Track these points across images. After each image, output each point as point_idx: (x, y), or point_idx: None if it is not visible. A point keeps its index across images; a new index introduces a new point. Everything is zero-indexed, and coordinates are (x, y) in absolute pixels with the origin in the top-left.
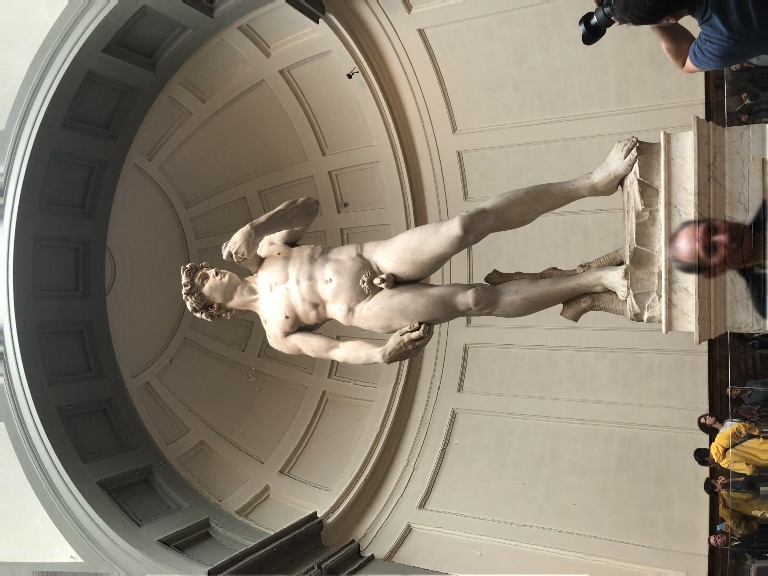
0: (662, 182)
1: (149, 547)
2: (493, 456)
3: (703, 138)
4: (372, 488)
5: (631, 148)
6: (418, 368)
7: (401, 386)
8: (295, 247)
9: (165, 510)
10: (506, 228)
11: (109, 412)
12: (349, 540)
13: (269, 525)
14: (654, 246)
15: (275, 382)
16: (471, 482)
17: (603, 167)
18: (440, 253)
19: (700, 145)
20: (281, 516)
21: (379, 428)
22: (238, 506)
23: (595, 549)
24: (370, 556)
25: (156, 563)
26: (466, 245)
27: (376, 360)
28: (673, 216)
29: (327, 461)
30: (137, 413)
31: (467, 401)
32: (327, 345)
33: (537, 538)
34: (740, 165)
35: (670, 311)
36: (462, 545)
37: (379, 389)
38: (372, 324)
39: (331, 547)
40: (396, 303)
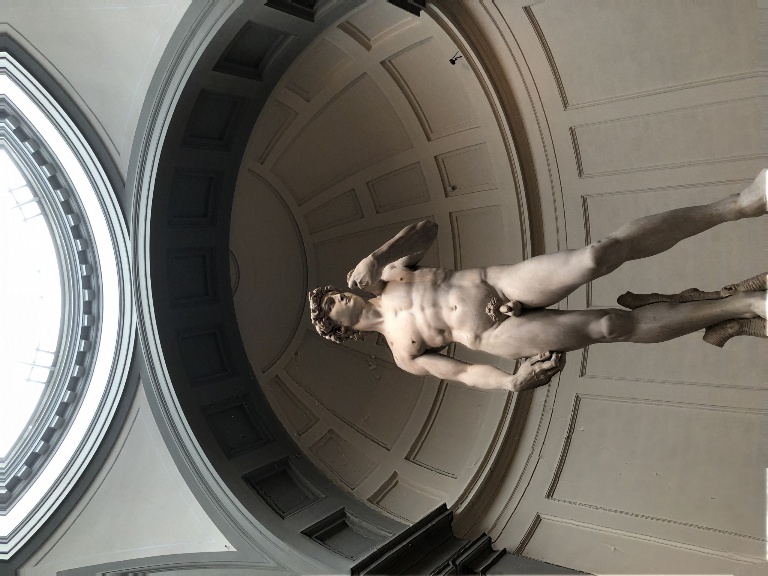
0: None
1: (294, 540)
2: (622, 444)
3: None
4: (498, 477)
5: None
6: None
7: None
8: (417, 270)
9: (303, 500)
10: None
11: (245, 408)
12: (479, 530)
13: (400, 513)
14: None
15: (395, 369)
16: (600, 471)
17: (752, 190)
18: (570, 284)
19: None
20: (411, 504)
21: (501, 415)
22: (369, 494)
23: (740, 548)
24: (502, 551)
25: (301, 555)
26: None
27: (507, 388)
28: None
29: (451, 447)
30: (270, 407)
31: (592, 386)
32: (455, 369)
33: (675, 535)
34: None
35: None
36: (595, 538)
37: None
38: (500, 351)
39: (463, 540)
40: (525, 332)
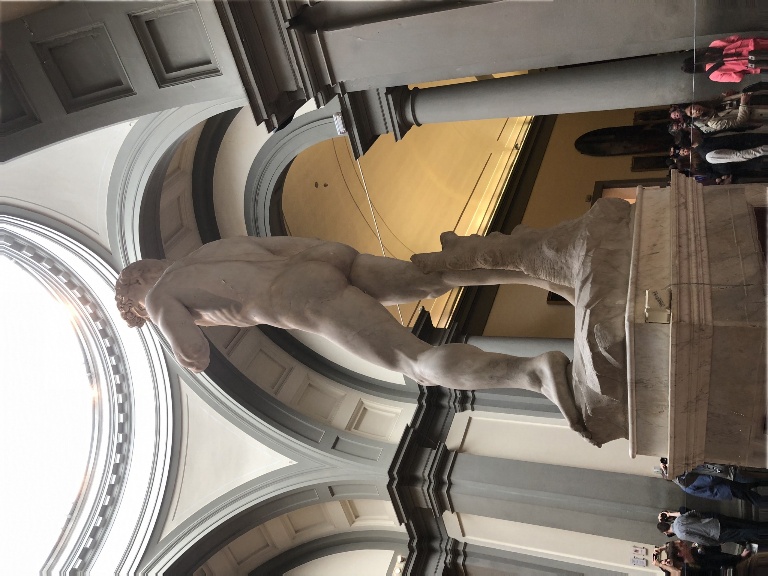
0: None
1: (170, 102)
2: None
3: None
4: None
5: None
6: None
7: None
8: (204, 316)
9: (98, 43)
10: None
11: None
12: None
13: None
14: None
15: None
16: None
17: None
18: None
19: None
20: None
21: None
22: None
23: None
24: None
25: None
26: None
27: None
28: None
29: None
30: None
31: None
32: None
33: None
34: None
35: None
36: None
37: None
38: None
39: None
40: None
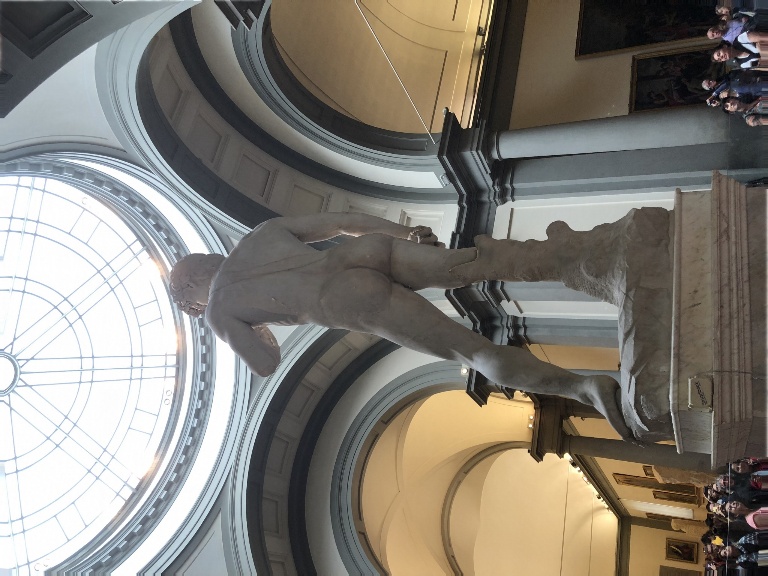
0: None
1: (131, 16)
2: None
3: None
4: None
5: None
6: None
7: None
8: None
9: None
10: None
11: None
12: None
13: None
14: None
15: None
16: None
17: None
18: None
19: None
20: None
21: None
22: None
23: None
24: None
25: None
26: None
27: None
28: None
29: None
30: None
31: None
32: None
33: None
34: None
35: None
36: None
37: None
38: None
39: None
40: None
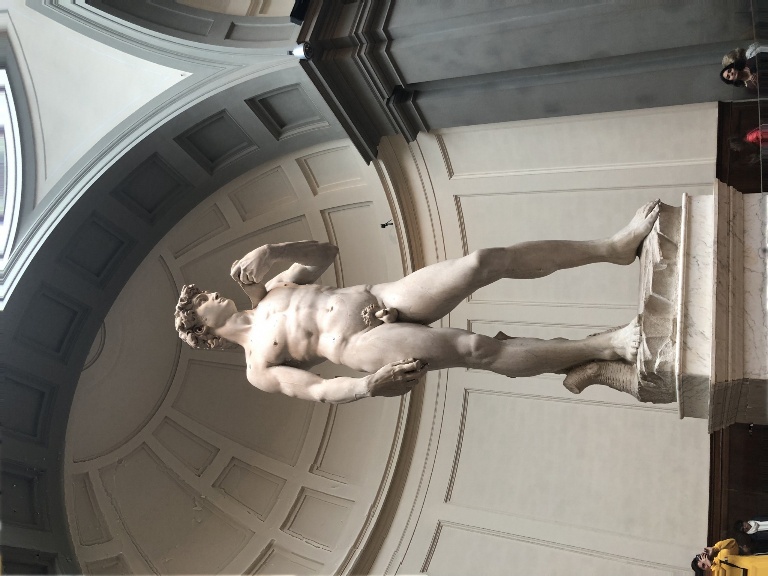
0: (682, 236)
1: None
2: None
3: (723, 198)
4: None
5: (653, 207)
6: (382, 537)
7: (359, 551)
8: None
9: None
10: (521, 273)
11: (35, 483)
12: None
13: None
14: (670, 295)
15: (221, 518)
16: None
17: None
18: (451, 286)
19: (720, 203)
20: None
21: None
22: None
23: None
24: None
25: None
26: (479, 281)
27: (359, 390)
28: (691, 265)
29: None
30: (63, 496)
31: None
32: (309, 378)
33: None
34: (759, 225)
35: (684, 353)
36: None
37: (333, 553)
38: (364, 356)
39: None
40: (394, 334)
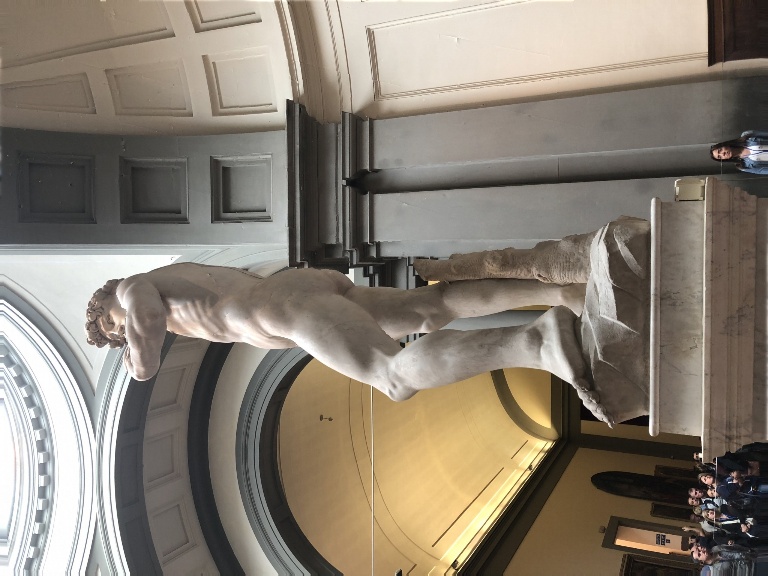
0: None
1: (216, 237)
2: None
3: None
4: (301, 2)
5: None
6: None
7: None
8: (173, 312)
9: (175, 175)
10: None
11: (36, 163)
12: (329, 85)
13: (248, 101)
14: None
15: None
16: None
17: None
18: None
19: None
20: (248, 85)
21: None
22: (209, 107)
23: None
24: (369, 125)
25: None
26: None
27: None
28: None
29: None
30: (46, 131)
31: None
32: None
33: None
34: None
35: None
36: (433, 30)
37: None
38: None
39: (329, 127)
40: None
